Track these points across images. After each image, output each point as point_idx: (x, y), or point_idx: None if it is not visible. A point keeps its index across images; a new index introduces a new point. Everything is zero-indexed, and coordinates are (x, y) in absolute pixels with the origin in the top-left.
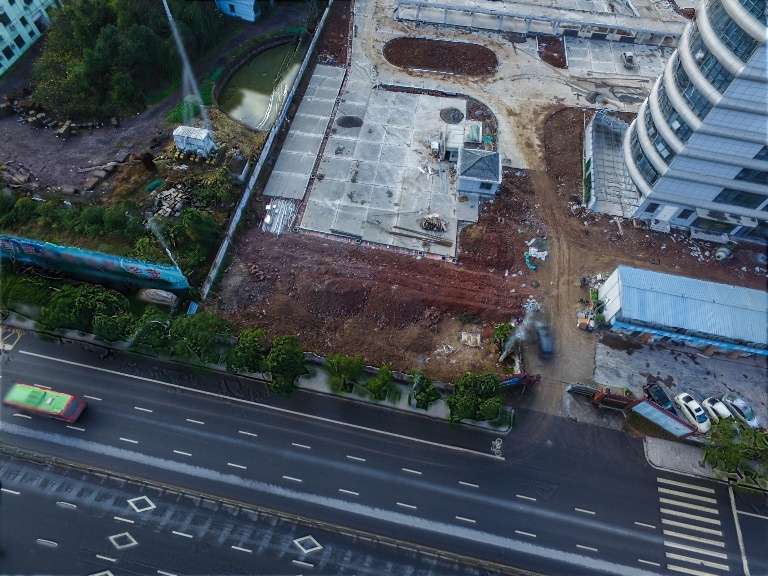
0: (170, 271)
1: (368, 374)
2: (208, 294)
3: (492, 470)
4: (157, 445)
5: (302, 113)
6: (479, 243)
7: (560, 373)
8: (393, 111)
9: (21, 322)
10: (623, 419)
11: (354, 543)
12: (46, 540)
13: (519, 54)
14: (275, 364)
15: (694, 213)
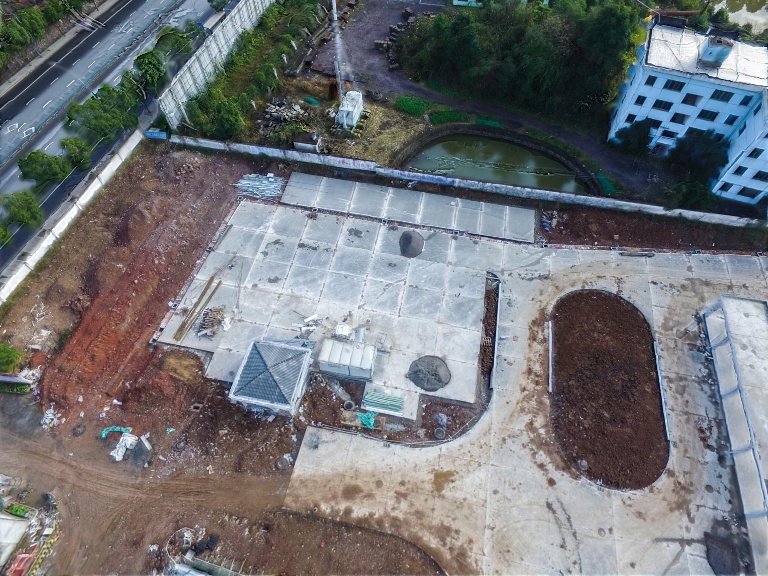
0: None
1: None
2: (174, 143)
3: None
4: (62, 134)
5: (426, 198)
6: None
7: None
8: (437, 293)
9: None
10: None
11: None
12: (32, 100)
13: (658, 547)
14: None
15: None
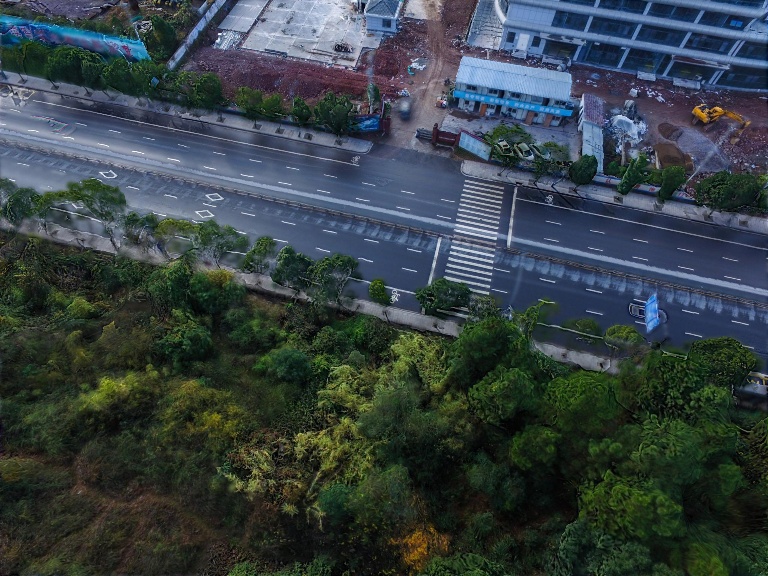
0: (137, 45)
1: (272, 119)
2: (167, 76)
3: (349, 170)
4: (122, 148)
5: None
6: (374, 57)
7: (413, 128)
8: None
9: (35, 84)
10: (452, 152)
11: (245, 198)
12: None
13: None
14: (199, 84)
15: (542, 39)
